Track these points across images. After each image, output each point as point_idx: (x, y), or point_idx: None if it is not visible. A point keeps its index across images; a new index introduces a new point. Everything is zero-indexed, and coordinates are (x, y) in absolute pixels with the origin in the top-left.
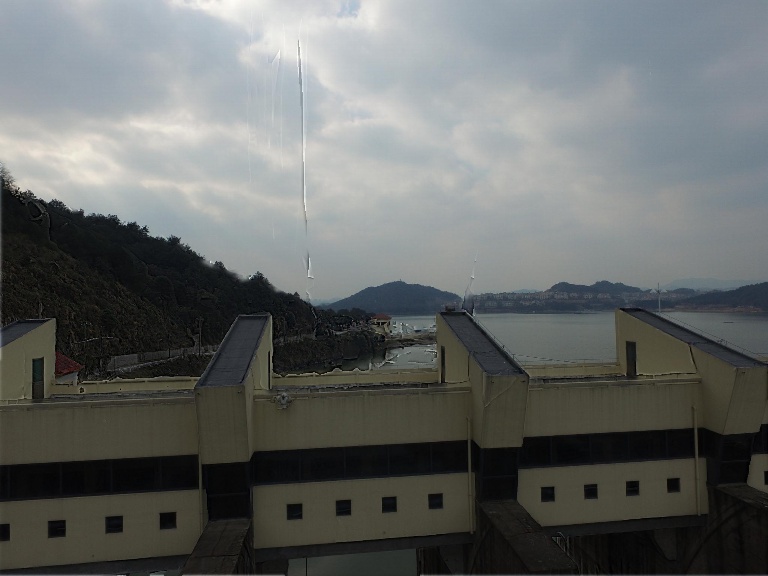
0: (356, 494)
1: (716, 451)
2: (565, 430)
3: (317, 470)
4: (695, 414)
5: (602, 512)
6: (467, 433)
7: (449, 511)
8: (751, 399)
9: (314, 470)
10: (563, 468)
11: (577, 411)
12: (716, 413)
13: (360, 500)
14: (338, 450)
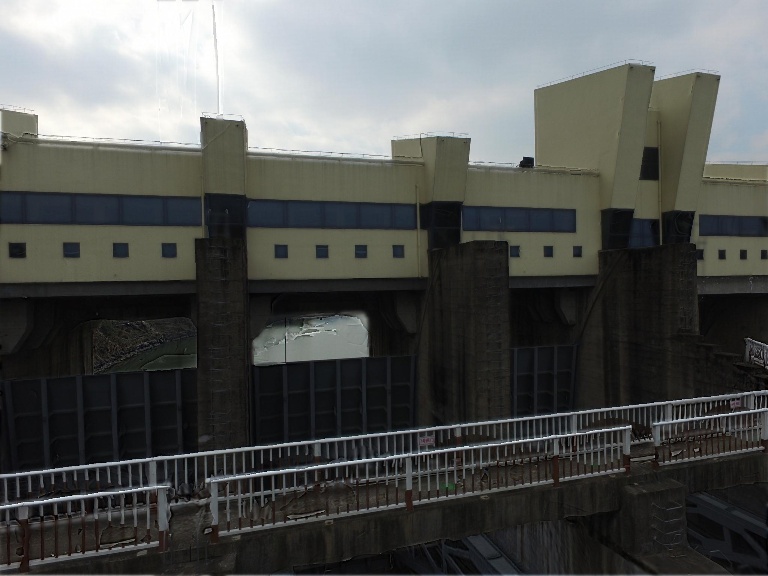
0: (86, 238)
1: (431, 218)
2: (298, 196)
3: (45, 215)
4: (417, 190)
5: (333, 270)
6: (201, 190)
7: (183, 260)
8: (453, 168)
9: (42, 216)
10: (296, 229)
11: (310, 180)
12: (430, 185)
13: (90, 244)
14: (66, 196)
